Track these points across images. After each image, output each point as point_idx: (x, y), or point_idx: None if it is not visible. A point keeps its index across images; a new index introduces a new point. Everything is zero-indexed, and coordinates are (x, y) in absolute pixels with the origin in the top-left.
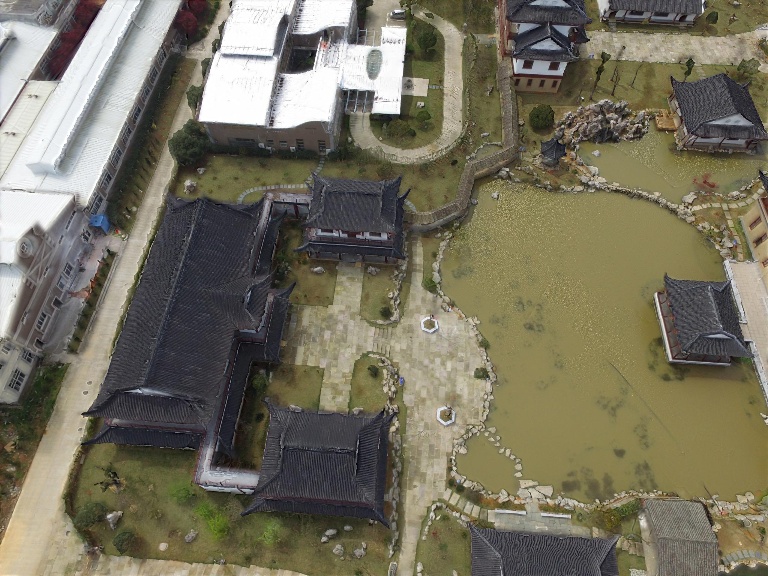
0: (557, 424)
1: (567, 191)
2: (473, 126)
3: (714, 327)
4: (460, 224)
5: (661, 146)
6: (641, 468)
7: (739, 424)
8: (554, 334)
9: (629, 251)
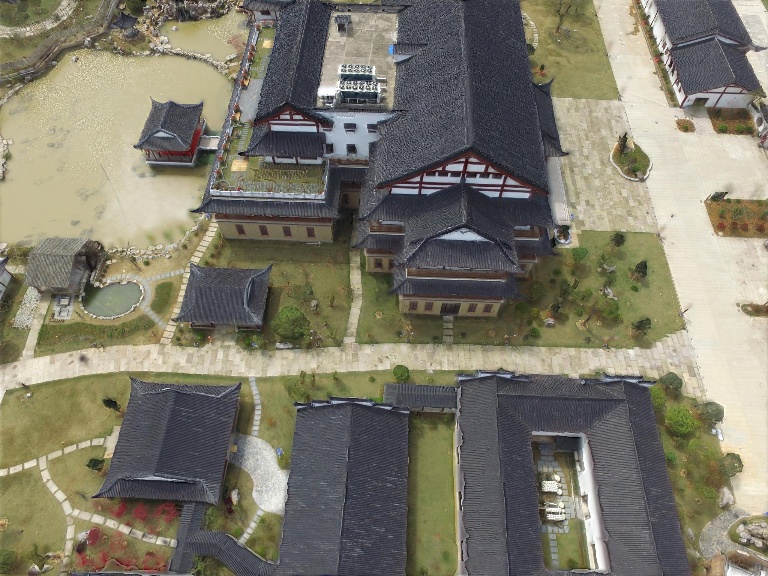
0: (39, 207)
1: (136, 55)
2: (81, 11)
3: (158, 127)
4: (34, 79)
5: (235, 24)
6: (86, 232)
7: (182, 204)
8: (68, 149)
9: (179, 100)
